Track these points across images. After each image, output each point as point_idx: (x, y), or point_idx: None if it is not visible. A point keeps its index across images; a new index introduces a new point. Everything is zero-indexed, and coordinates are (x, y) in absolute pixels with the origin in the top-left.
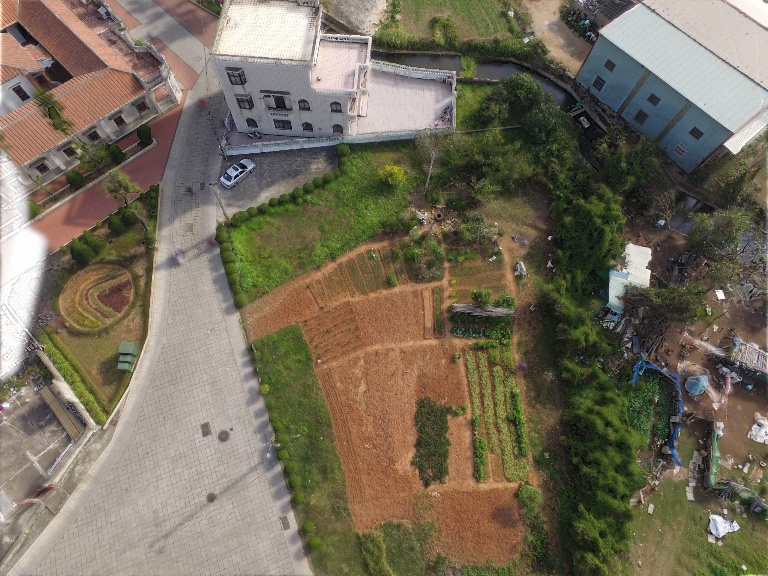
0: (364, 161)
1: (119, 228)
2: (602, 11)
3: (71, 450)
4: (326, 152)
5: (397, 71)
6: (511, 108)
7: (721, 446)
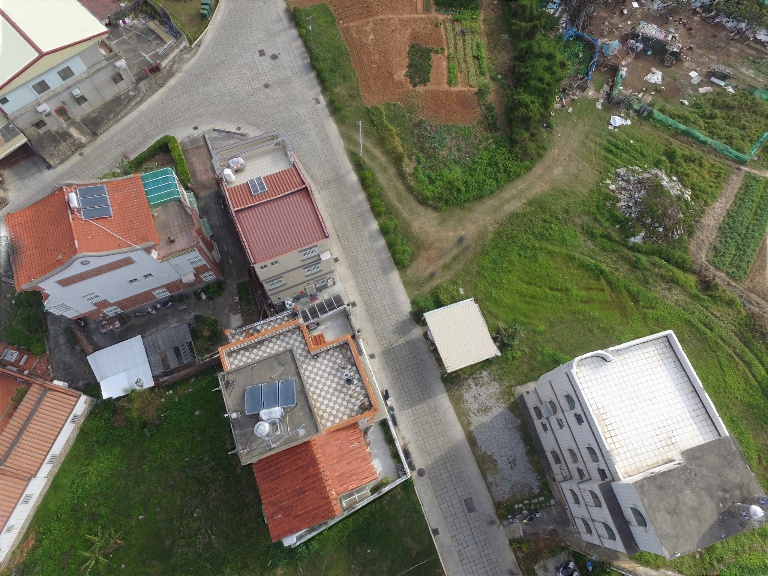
0: None
1: None
2: None
3: (173, 45)
4: None
5: None
6: None
7: (624, 83)
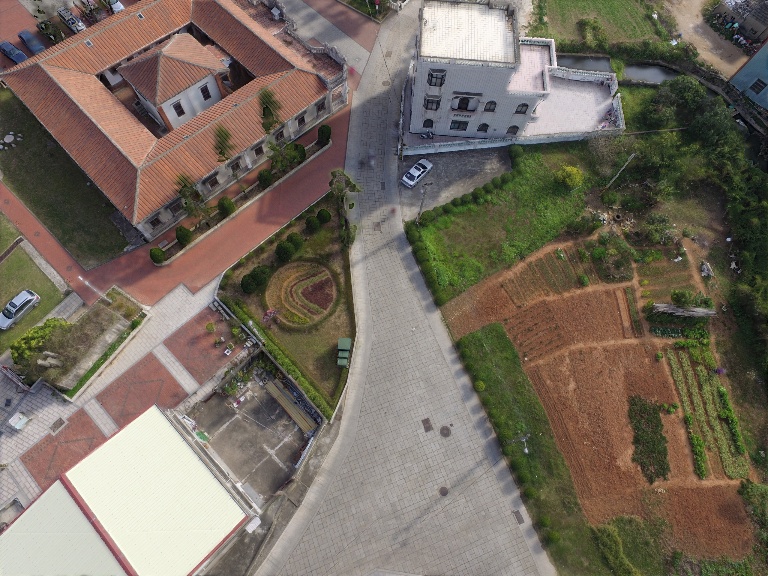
0: (536, 162)
1: (316, 226)
2: (754, 14)
3: (312, 444)
4: (498, 153)
5: (555, 73)
6: (675, 110)
7: None
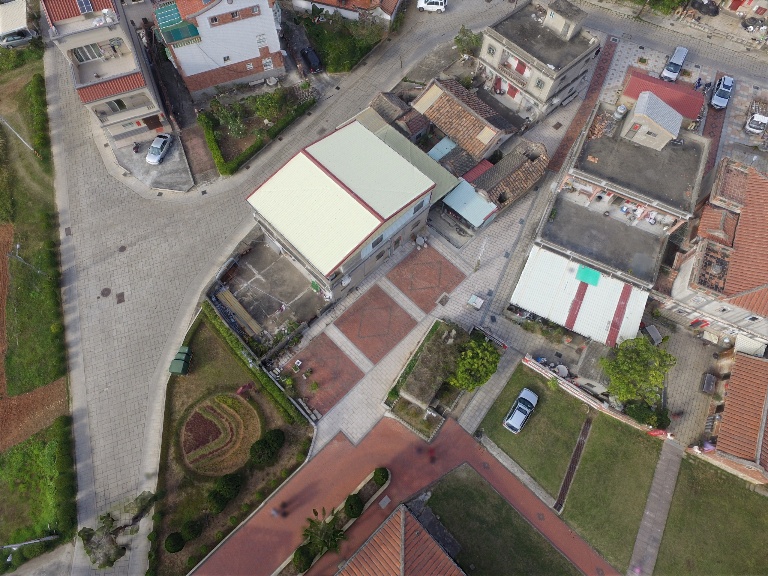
0: None
1: None
2: None
3: None
4: None
5: None
6: None
7: None
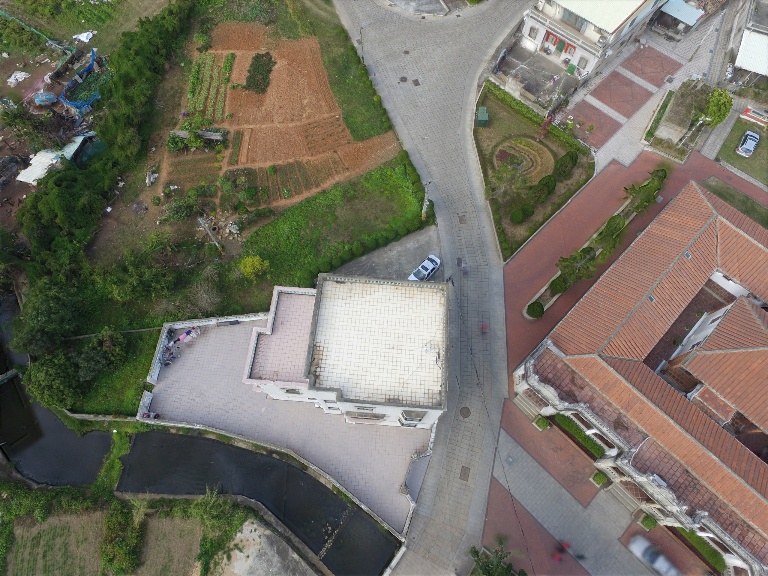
0: None
1: None
2: None
3: None
4: None
5: None
6: None
7: None
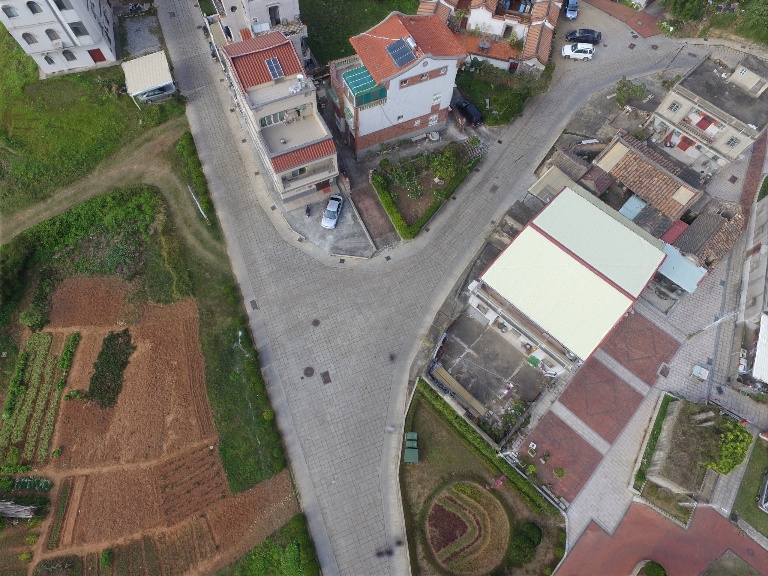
0: None
1: None
2: None
3: None
4: None
5: None
6: None
7: None
